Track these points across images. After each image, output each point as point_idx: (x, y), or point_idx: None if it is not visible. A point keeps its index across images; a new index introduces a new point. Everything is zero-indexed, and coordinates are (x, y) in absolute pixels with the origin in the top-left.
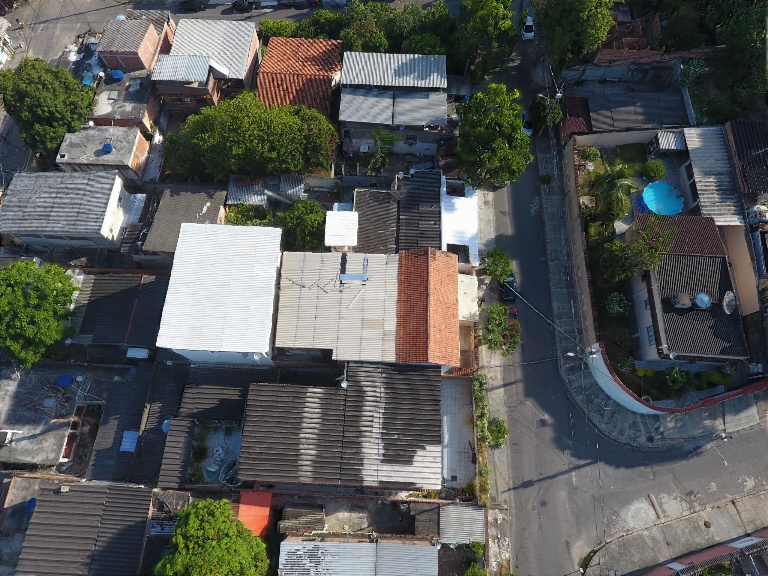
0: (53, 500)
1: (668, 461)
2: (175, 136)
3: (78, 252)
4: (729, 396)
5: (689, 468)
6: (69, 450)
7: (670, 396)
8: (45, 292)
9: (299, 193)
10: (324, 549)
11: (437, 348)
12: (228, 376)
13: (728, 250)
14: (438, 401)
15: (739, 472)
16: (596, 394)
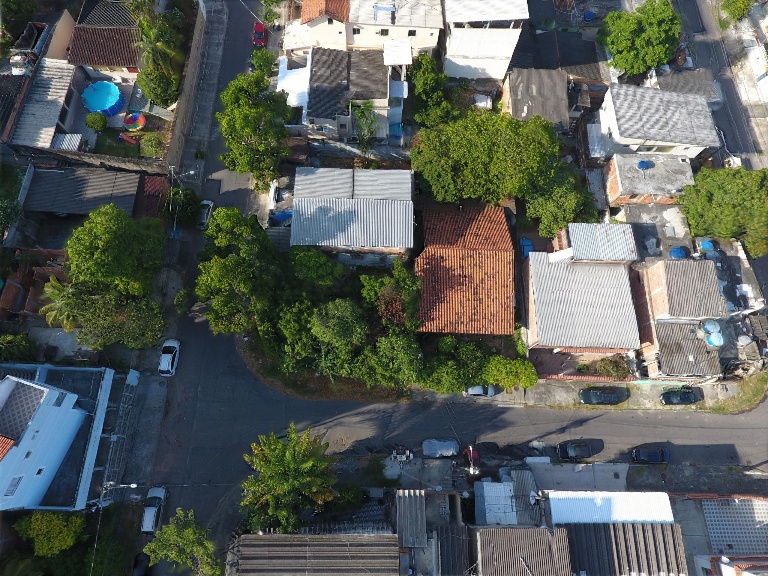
0: None
1: None
2: (584, 197)
3: None
4: None
5: None
6: (570, 0)
7: None
8: None
9: None
10: None
11: None
12: None
13: None
14: None
15: None
16: None
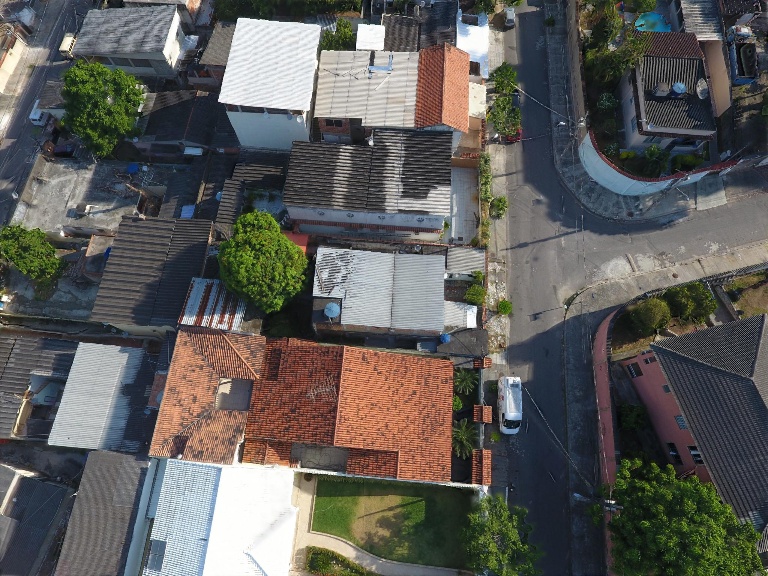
0: (132, 225)
1: (645, 231)
2: None
3: (140, 80)
4: (699, 171)
5: (663, 236)
6: None
7: (648, 170)
8: (121, 85)
9: (333, 29)
10: (352, 254)
11: (450, 115)
12: (272, 158)
13: (708, 68)
14: (449, 157)
15: (706, 239)
16: (585, 181)
